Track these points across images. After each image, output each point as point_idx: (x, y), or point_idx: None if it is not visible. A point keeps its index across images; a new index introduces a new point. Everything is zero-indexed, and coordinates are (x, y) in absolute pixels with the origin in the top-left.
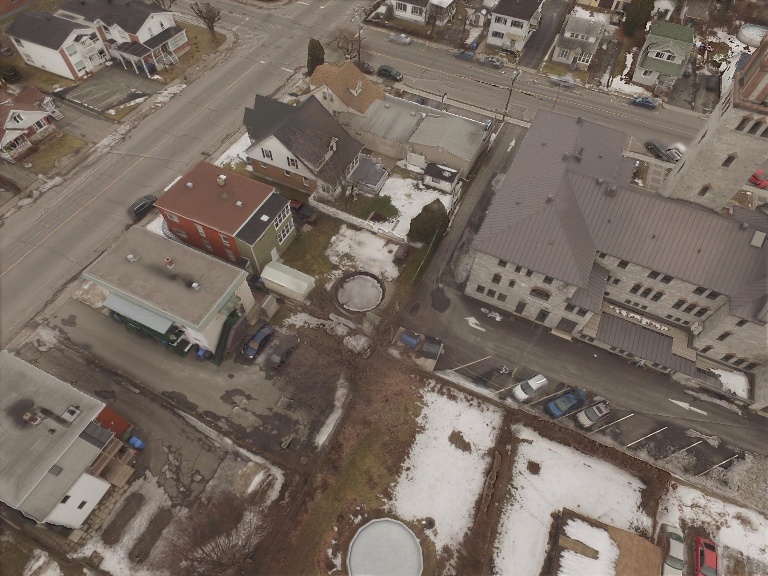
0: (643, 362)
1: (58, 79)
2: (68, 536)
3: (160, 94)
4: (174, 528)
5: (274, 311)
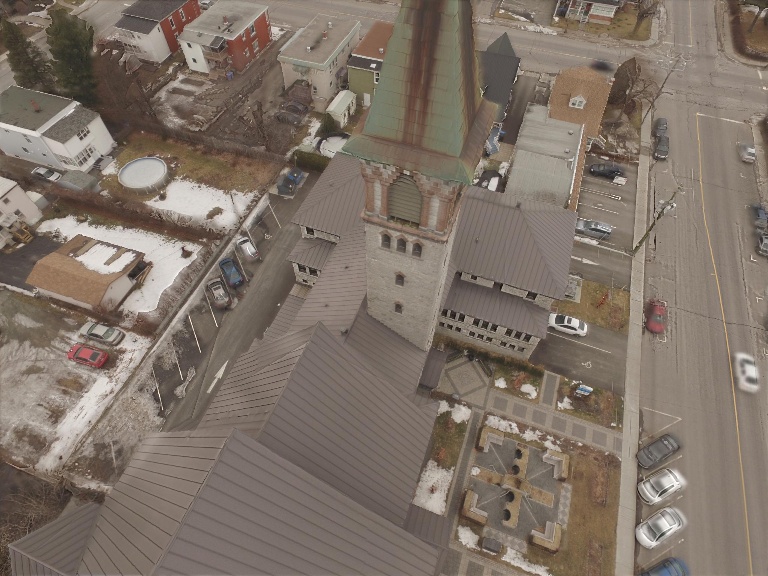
0: None
1: None
2: (188, 69)
3: (537, 26)
4: (183, 98)
5: (321, 111)
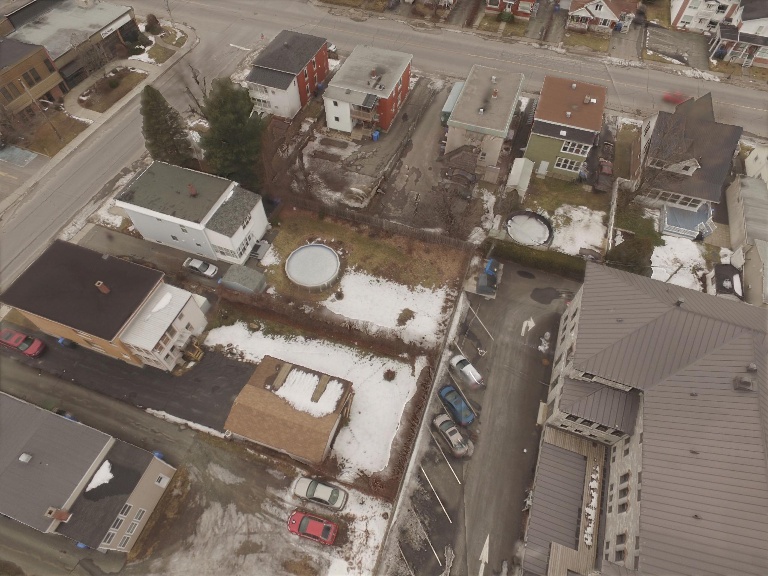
0: (529, 503)
1: (665, 18)
2: (324, 126)
3: (694, 70)
4: (330, 164)
5: (491, 180)
